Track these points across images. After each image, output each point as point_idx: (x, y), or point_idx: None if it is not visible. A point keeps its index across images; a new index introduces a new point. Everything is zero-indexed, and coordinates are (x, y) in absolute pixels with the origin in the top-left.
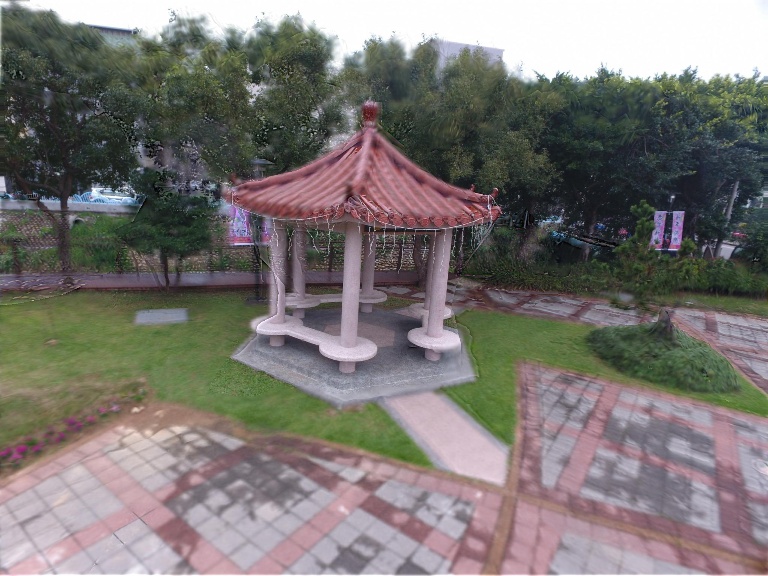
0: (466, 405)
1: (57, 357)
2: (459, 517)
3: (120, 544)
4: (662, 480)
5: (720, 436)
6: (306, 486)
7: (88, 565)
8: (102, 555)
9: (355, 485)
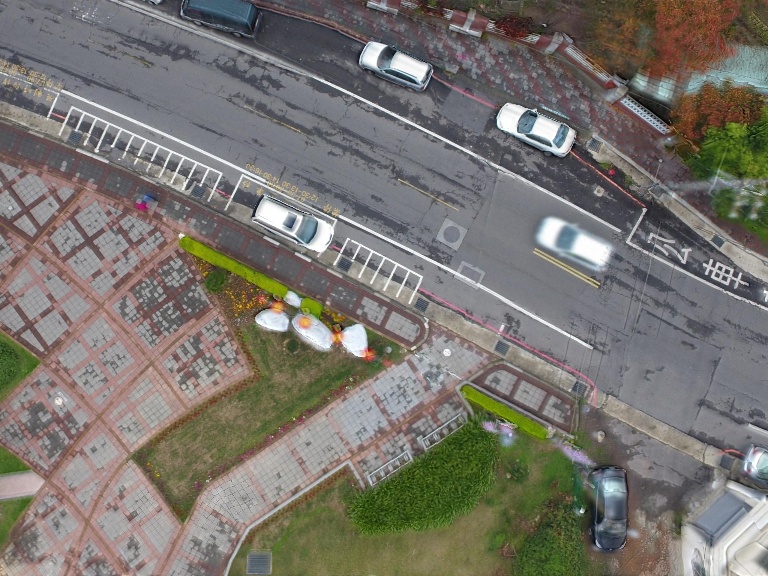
0: (10, 474)
1: None
2: (52, 497)
3: (42, 567)
4: (55, 439)
5: (43, 399)
6: (34, 529)
7: (45, 572)
8: (43, 570)
9: (36, 517)
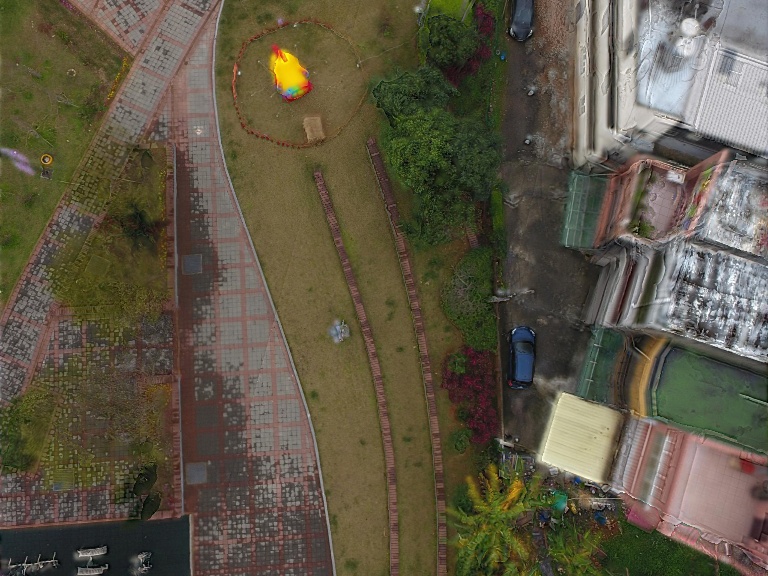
0: None
1: (14, 4)
2: None
3: None
4: None
5: None
6: None
7: None
8: None
9: None
